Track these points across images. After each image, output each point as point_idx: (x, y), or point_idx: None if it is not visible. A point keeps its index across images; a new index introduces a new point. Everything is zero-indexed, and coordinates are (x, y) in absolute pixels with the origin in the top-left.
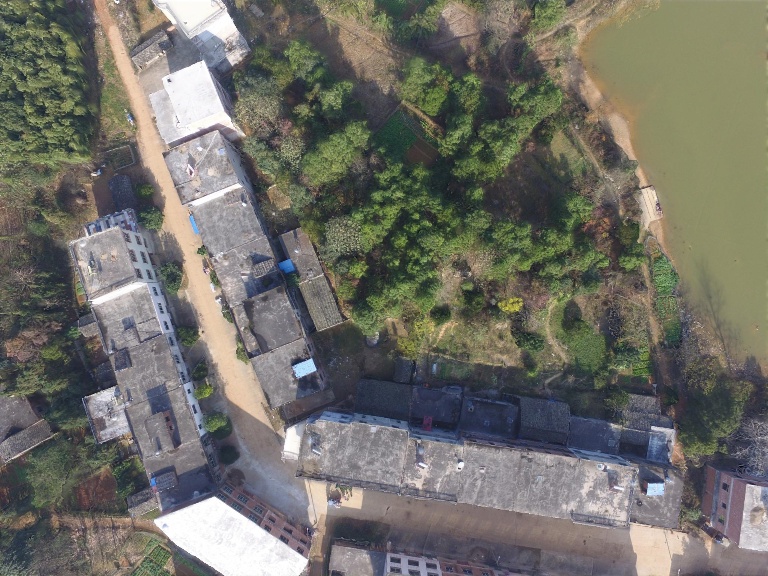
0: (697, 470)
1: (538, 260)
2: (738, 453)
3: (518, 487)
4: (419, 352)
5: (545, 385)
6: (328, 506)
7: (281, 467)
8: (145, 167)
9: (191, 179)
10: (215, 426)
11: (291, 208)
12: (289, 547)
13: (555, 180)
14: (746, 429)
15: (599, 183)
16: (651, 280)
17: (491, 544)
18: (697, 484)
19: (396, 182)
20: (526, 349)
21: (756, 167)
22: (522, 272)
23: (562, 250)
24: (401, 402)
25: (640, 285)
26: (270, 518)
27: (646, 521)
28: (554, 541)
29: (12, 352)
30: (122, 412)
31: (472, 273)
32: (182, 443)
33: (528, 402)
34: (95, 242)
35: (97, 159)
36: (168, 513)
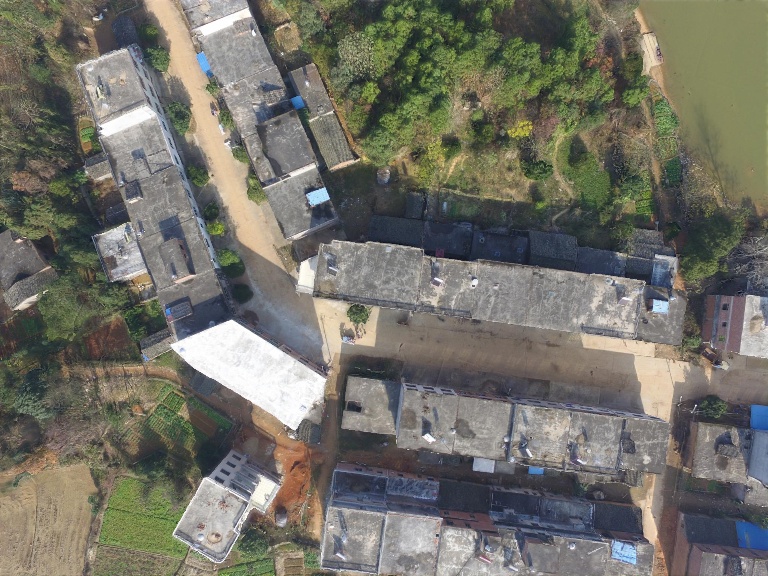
0: (697, 302)
1: (547, 84)
2: (738, 267)
3: (530, 302)
4: (431, 180)
5: (552, 222)
6: (342, 345)
7: (294, 308)
8: (149, 11)
9: (200, 3)
10: (229, 258)
11: (299, 50)
12: (307, 367)
13: (560, 19)
14: (745, 246)
15: (603, 24)
16: (653, 122)
17: (502, 377)
18: (698, 314)
19: (408, 0)
20: (534, 184)
21: (751, 15)
22: (531, 100)
23: (570, 72)
24: (413, 235)
25: (643, 123)
26: (286, 349)
27: (651, 339)
28: (562, 372)
29: (18, 185)
30: (133, 250)
31: (482, 103)
32: (196, 274)
33: (537, 234)
34: (103, 66)
35: (98, 3)
36: (185, 338)
